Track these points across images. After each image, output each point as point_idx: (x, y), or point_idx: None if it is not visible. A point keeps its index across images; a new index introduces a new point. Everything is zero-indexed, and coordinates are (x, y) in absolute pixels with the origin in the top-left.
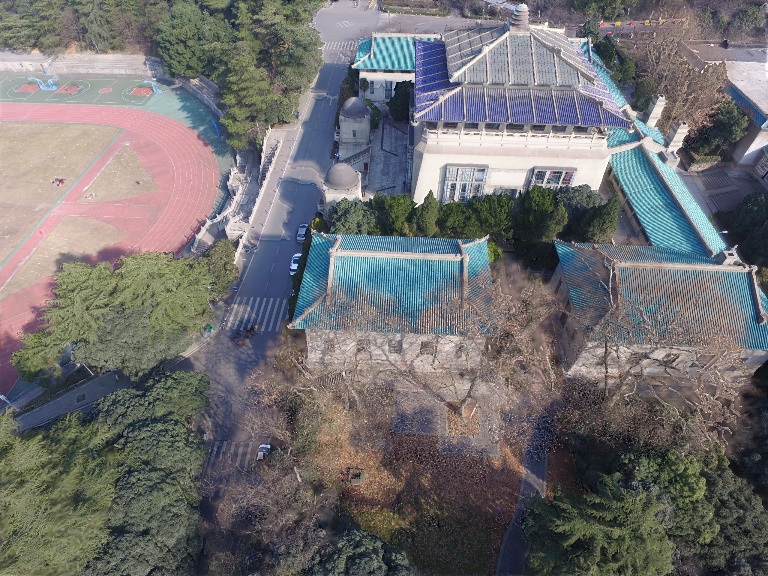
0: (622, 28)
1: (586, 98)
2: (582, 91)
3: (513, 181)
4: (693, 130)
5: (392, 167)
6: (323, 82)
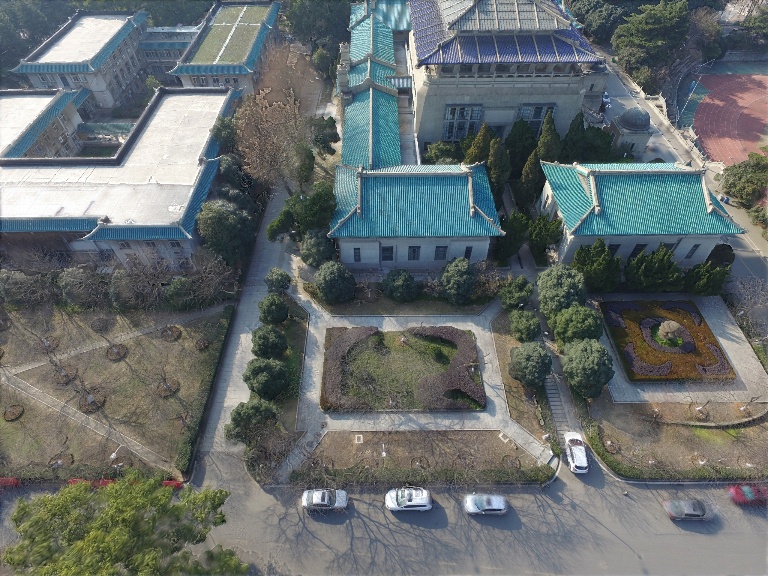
0: None
1: None
2: None
3: None
4: None
5: None
6: (765, 276)
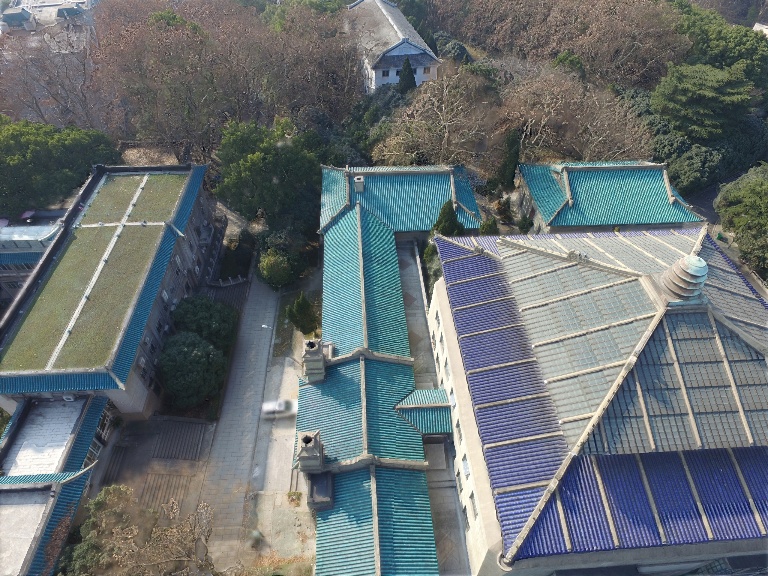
0: None
1: None
2: None
3: None
4: None
5: None
6: None
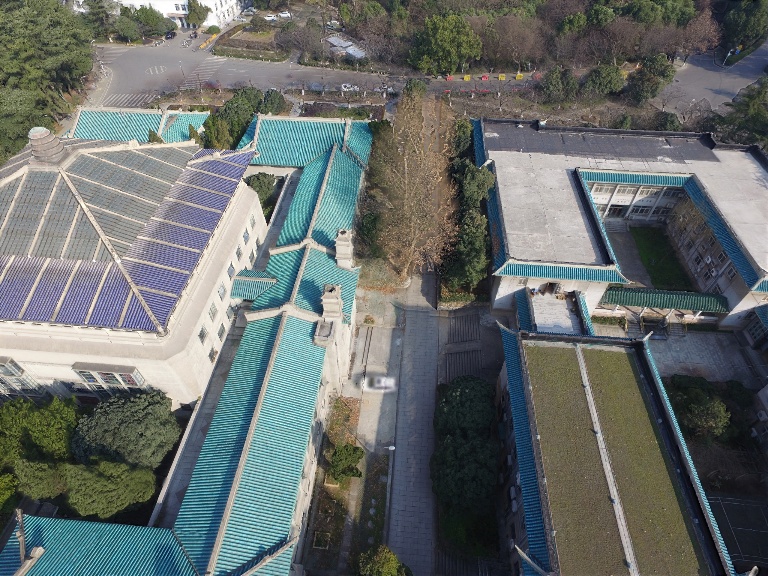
0: (471, 83)
1: (122, 274)
2: (129, 259)
3: (65, 374)
4: (429, 262)
5: None
6: None
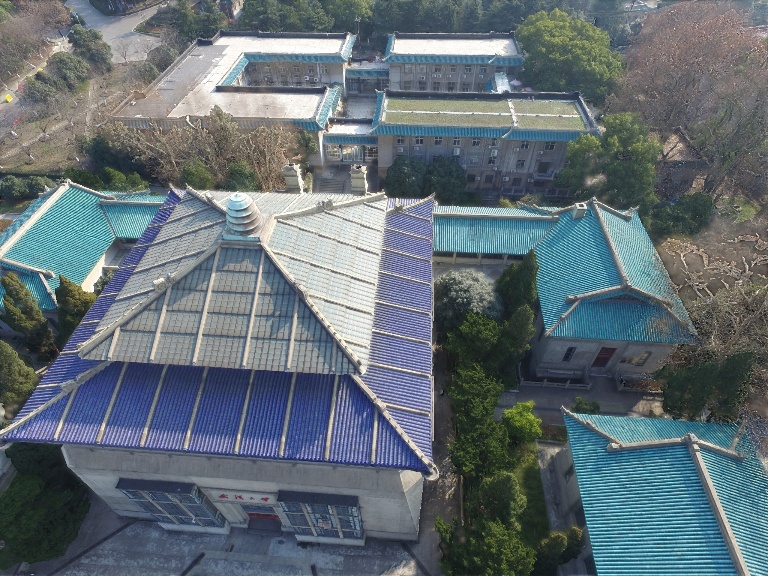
0: None
1: None
2: None
3: None
4: None
5: (243, 570)
6: None
